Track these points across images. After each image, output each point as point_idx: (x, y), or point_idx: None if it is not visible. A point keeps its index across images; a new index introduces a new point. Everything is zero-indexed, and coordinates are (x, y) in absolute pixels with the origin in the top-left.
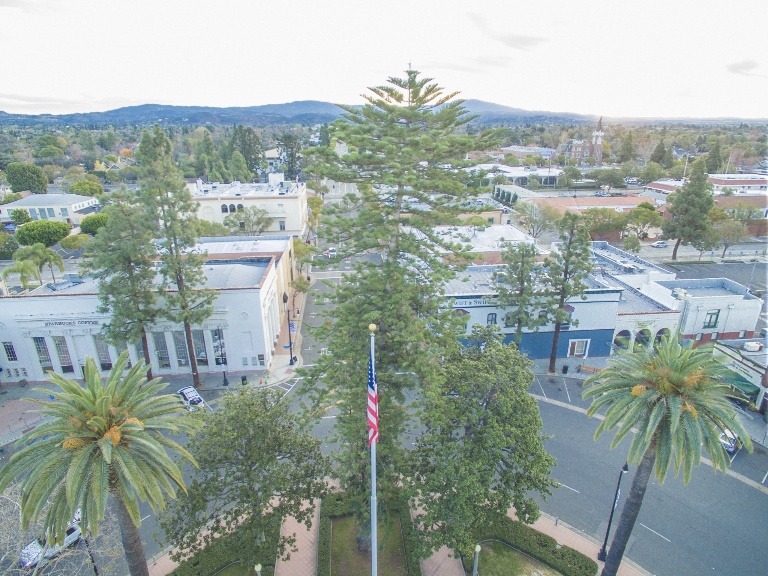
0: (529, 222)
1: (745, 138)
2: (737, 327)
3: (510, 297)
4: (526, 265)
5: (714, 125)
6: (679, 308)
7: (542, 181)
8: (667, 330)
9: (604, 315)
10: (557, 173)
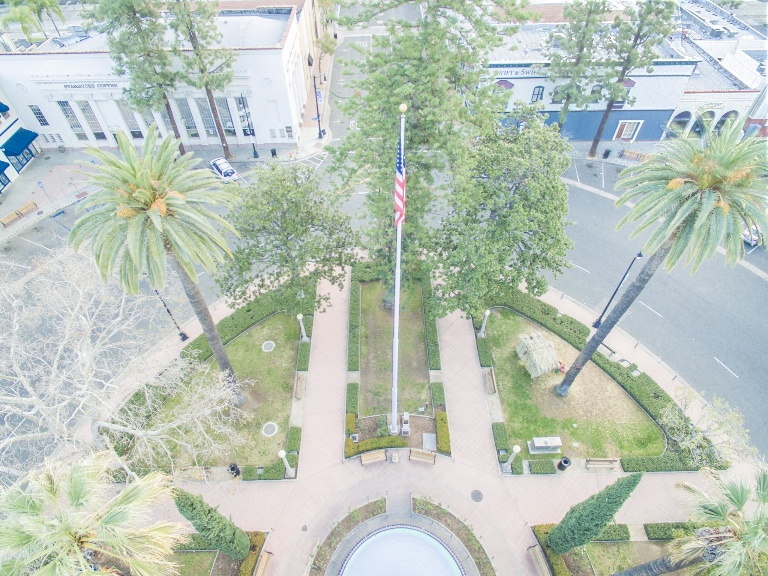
0: None
1: None
2: None
3: (563, 67)
4: (591, 25)
5: None
6: (760, 86)
7: None
8: (735, 113)
9: (667, 92)
10: None
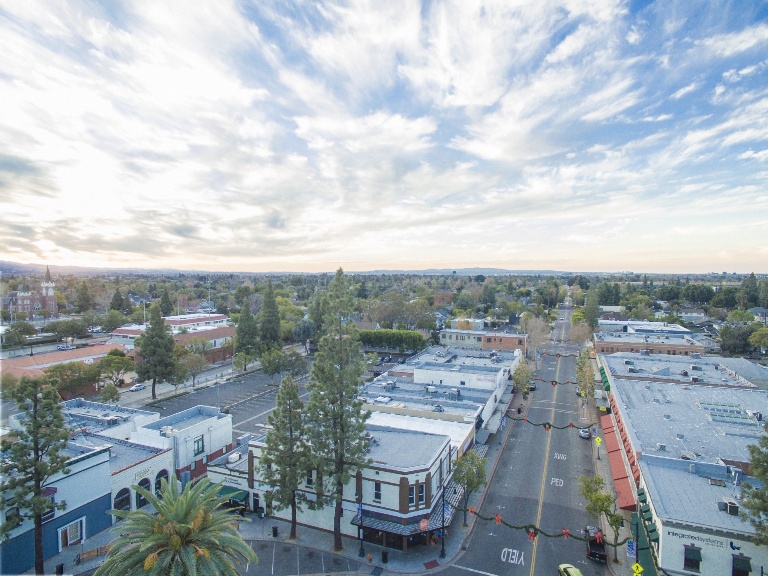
0: None
1: (185, 285)
2: (220, 445)
3: None
4: None
5: (159, 275)
6: (170, 446)
7: None
8: (164, 471)
9: (95, 482)
10: (2, 330)
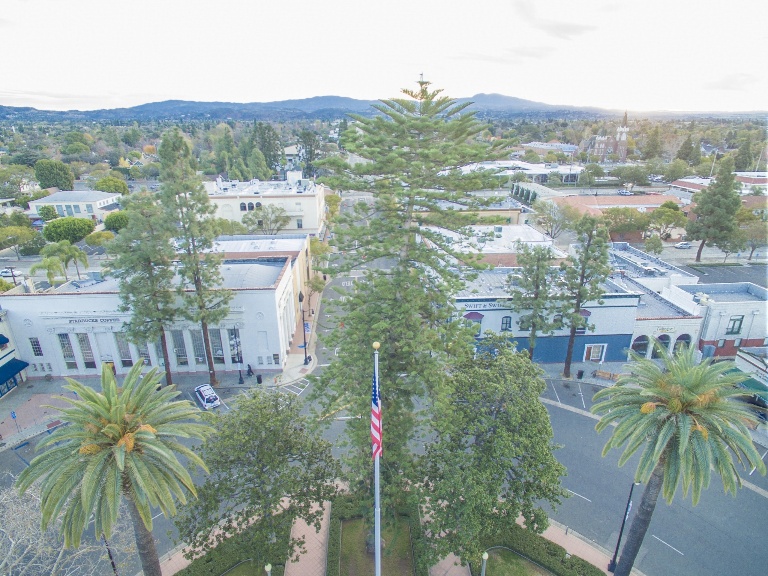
0: (548, 221)
1: None
2: (762, 333)
3: (524, 300)
4: (541, 269)
5: (746, 119)
6: (701, 313)
7: (563, 179)
8: (688, 336)
9: (622, 320)
10: (579, 170)
